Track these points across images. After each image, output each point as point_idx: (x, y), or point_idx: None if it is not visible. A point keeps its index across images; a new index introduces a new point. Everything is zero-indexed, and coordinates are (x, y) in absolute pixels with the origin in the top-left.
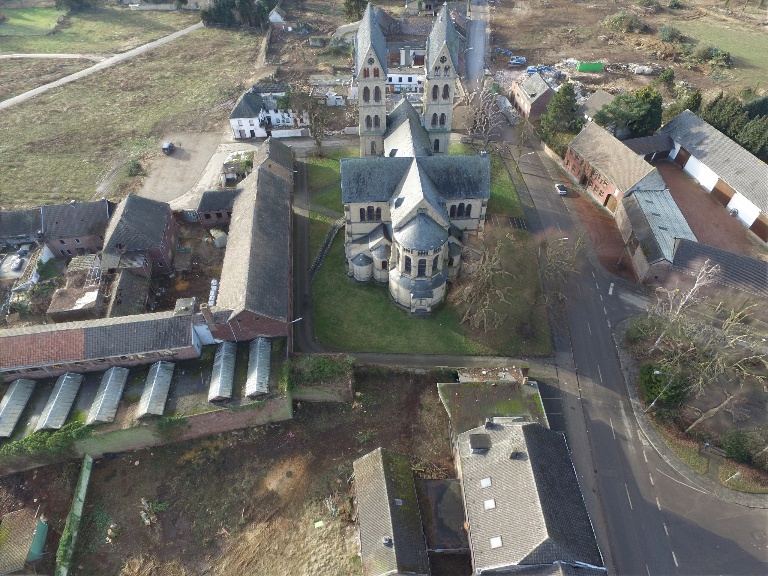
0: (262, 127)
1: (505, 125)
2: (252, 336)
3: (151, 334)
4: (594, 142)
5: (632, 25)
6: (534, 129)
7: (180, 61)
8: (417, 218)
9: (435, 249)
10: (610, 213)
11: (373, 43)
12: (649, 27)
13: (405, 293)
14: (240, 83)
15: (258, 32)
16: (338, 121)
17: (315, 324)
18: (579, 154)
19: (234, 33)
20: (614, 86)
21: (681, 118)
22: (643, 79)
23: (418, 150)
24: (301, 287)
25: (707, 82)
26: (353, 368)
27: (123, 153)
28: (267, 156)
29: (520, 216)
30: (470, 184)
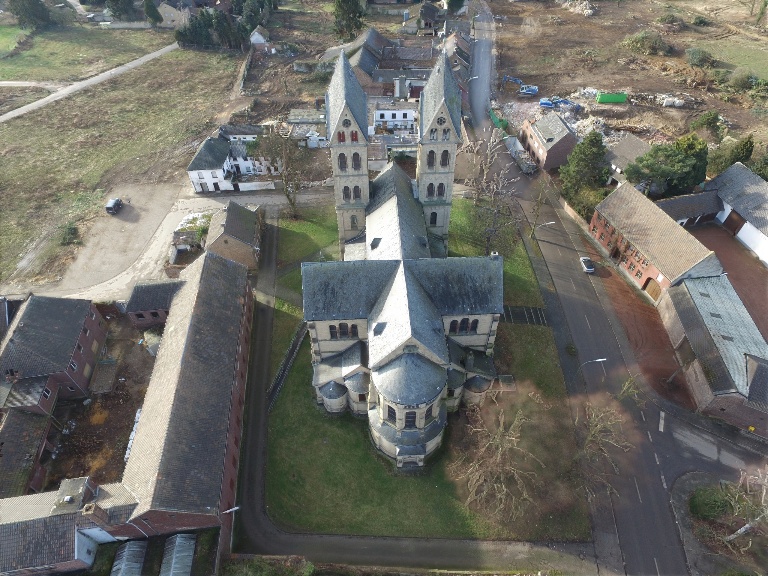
0: (227, 179)
1: (516, 173)
2: (169, 530)
3: (15, 544)
4: (629, 208)
5: (656, 46)
6: (551, 180)
7: (146, 90)
8: (403, 358)
9: (428, 399)
10: (651, 300)
11: (349, 101)
12: (674, 48)
13: (389, 444)
14: (211, 118)
15: (238, 55)
16: (320, 168)
17: (267, 484)
18: (610, 222)
19: (211, 56)
20: (640, 121)
21: (731, 173)
22: (674, 113)
23: (407, 244)
24: (254, 419)
25: (749, 117)
26: (312, 573)
27: (60, 212)
28: (222, 230)
29: (538, 305)
30: (477, 295)
